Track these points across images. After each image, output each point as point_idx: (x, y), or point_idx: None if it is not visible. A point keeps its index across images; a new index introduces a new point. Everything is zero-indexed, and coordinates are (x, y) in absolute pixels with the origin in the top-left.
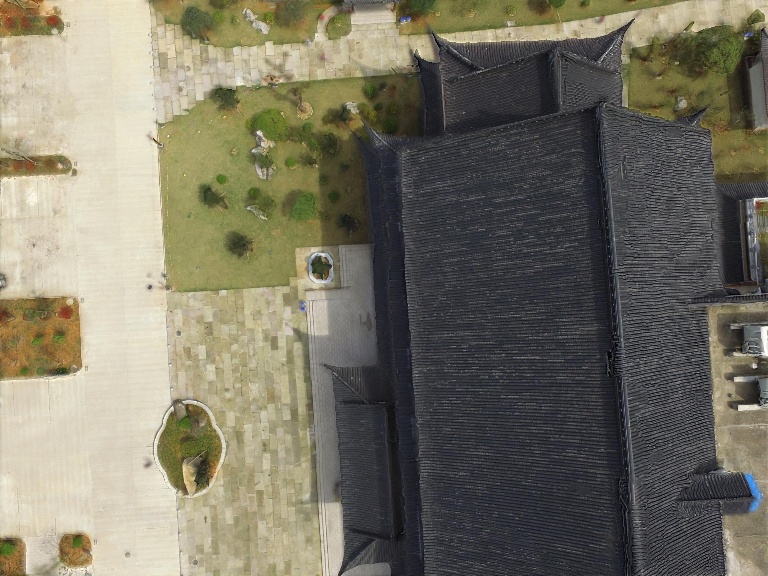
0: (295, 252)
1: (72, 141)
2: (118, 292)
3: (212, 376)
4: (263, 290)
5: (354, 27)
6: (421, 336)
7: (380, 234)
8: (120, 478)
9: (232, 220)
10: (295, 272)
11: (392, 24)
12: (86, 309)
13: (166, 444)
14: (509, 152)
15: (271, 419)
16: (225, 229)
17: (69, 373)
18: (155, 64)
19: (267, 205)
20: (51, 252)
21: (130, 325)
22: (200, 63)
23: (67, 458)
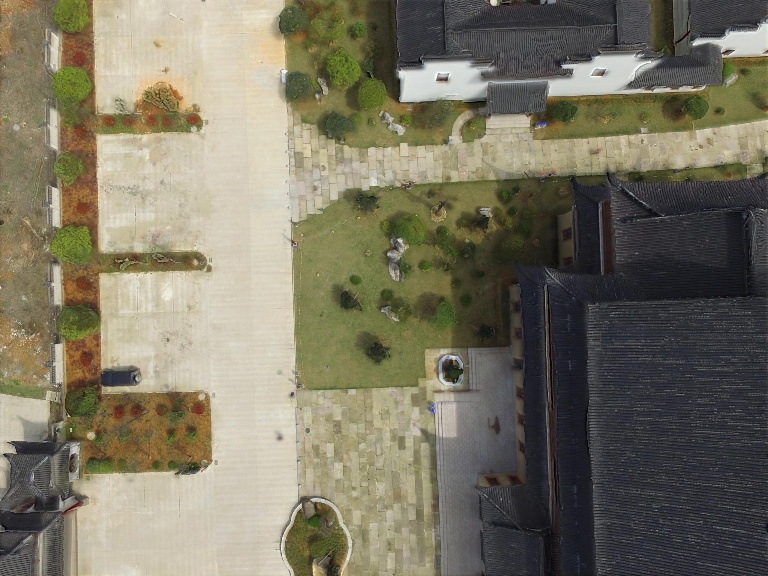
0: (424, 353)
1: (208, 237)
2: (249, 388)
3: (340, 474)
4: (392, 390)
5: (488, 131)
6: (605, 488)
7: (532, 357)
8: (247, 572)
9: (364, 320)
10: (424, 373)
11: (526, 129)
12: (217, 404)
13: (294, 541)
14: (715, 323)
15: (397, 518)
16: (356, 329)
17: (200, 467)
18: (291, 163)
19: (405, 312)
20: (185, 347)
21: (260, 421)
22: (335, 163)
23: (195, 551)
